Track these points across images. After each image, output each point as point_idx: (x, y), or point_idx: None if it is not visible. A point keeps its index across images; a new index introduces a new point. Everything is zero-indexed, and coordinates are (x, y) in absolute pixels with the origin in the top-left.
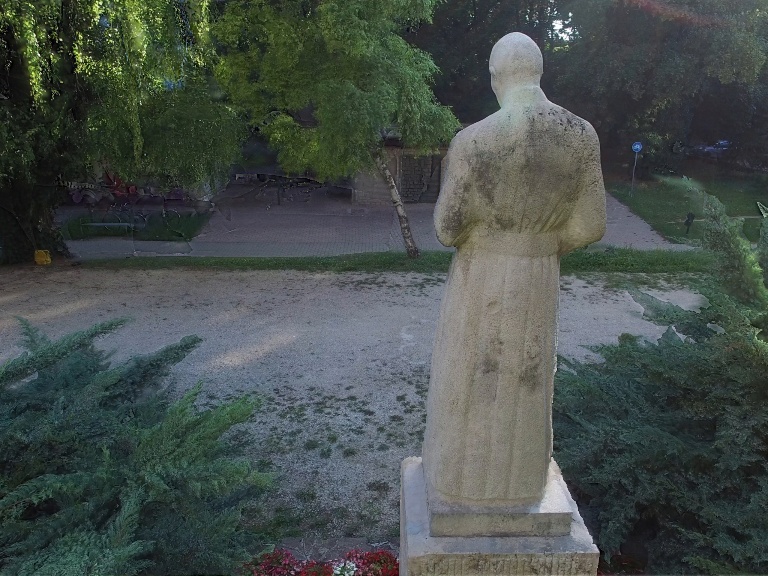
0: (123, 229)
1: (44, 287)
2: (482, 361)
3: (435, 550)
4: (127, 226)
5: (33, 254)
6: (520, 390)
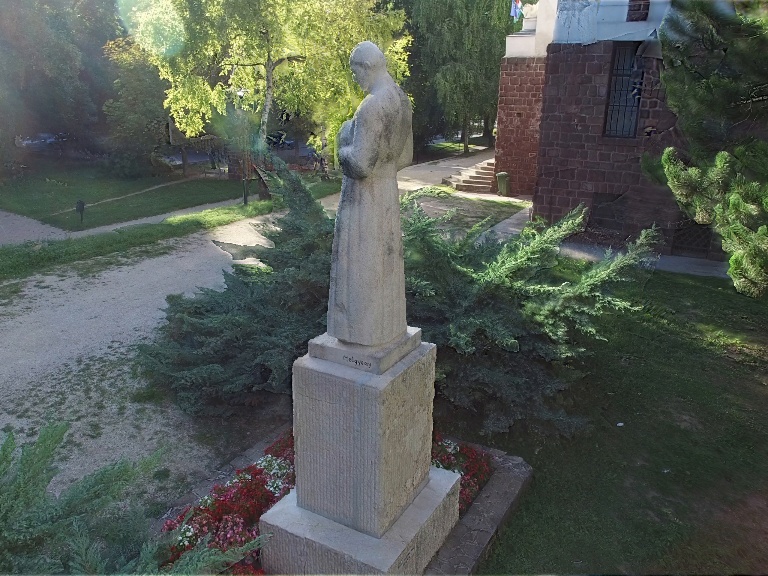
0: None
1: None
2: None
3: (390, 379)
4: None
5: None
6: (400, 262)
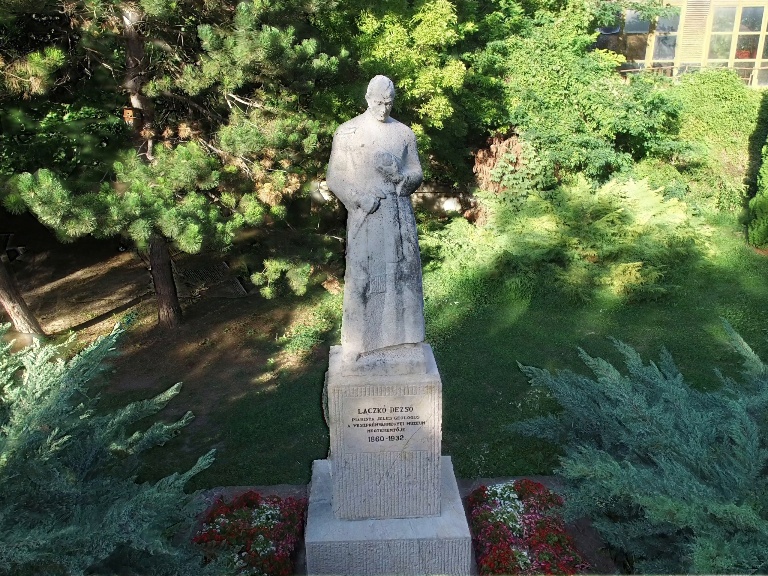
0: None
1: None
2: None
3: None
4: None
5: None
6: None
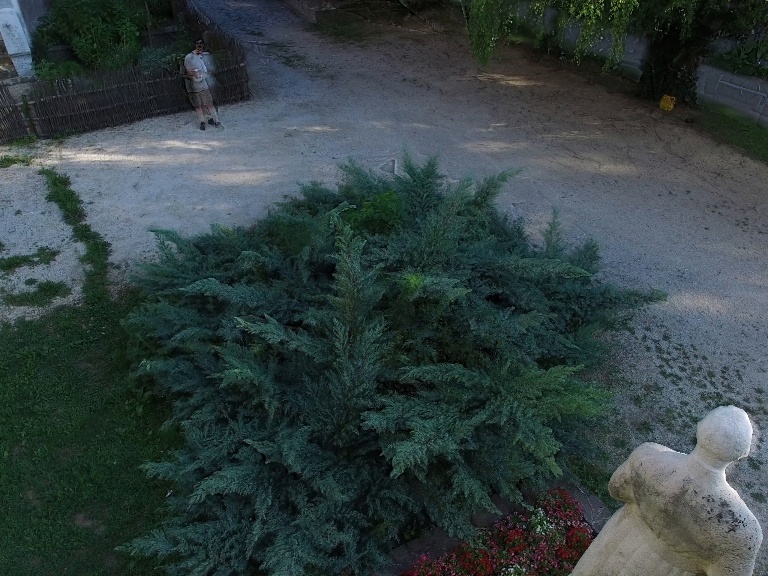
0: (757, 98)
1: (645, 138)
2: None
3: None
4: (763, 97)
5: (662, 96)
6: None
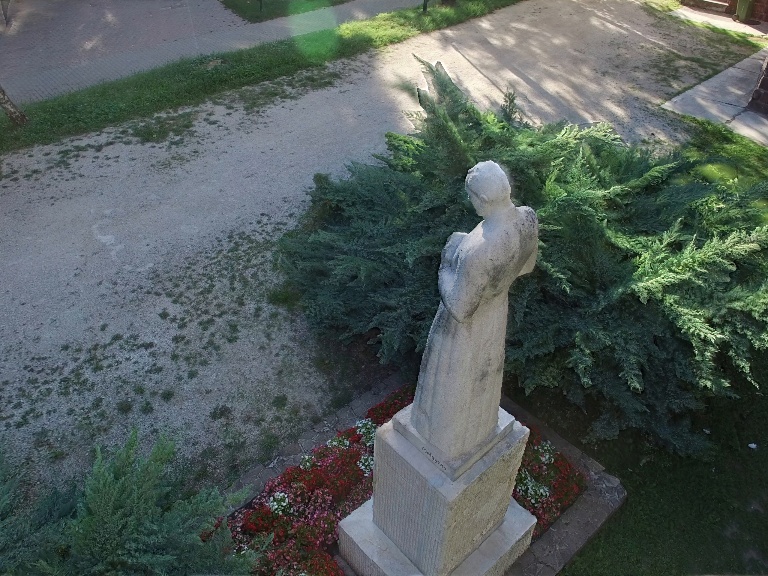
0: None
1: None
2: (480, 375)
3: (462, 488)
4: None
5: None
6: None
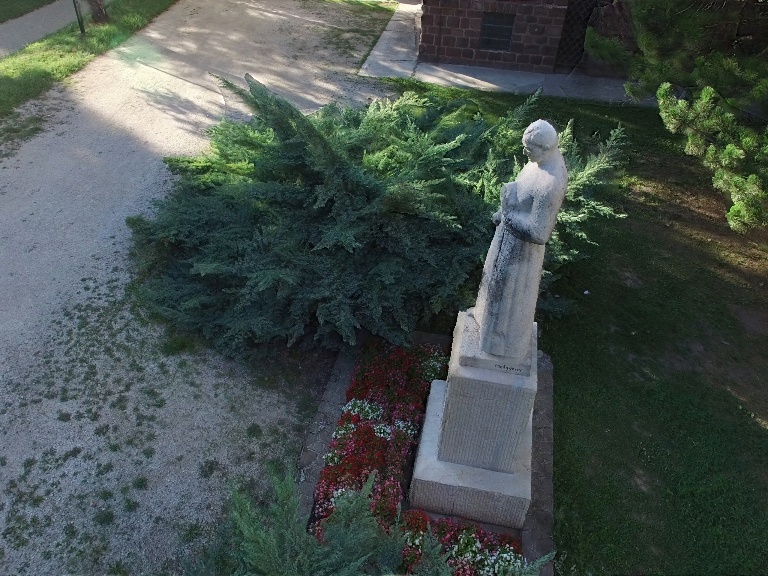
0: None
1: None
2: None
3: None
4: None
5: None
6: None
